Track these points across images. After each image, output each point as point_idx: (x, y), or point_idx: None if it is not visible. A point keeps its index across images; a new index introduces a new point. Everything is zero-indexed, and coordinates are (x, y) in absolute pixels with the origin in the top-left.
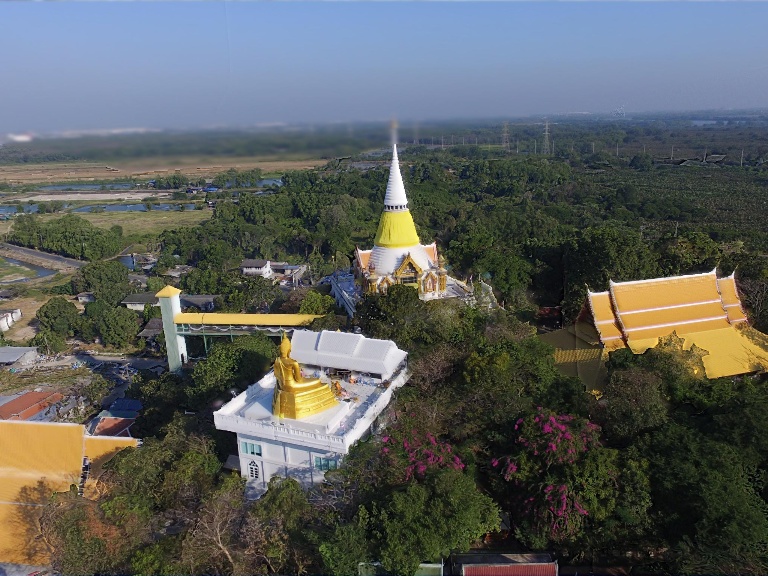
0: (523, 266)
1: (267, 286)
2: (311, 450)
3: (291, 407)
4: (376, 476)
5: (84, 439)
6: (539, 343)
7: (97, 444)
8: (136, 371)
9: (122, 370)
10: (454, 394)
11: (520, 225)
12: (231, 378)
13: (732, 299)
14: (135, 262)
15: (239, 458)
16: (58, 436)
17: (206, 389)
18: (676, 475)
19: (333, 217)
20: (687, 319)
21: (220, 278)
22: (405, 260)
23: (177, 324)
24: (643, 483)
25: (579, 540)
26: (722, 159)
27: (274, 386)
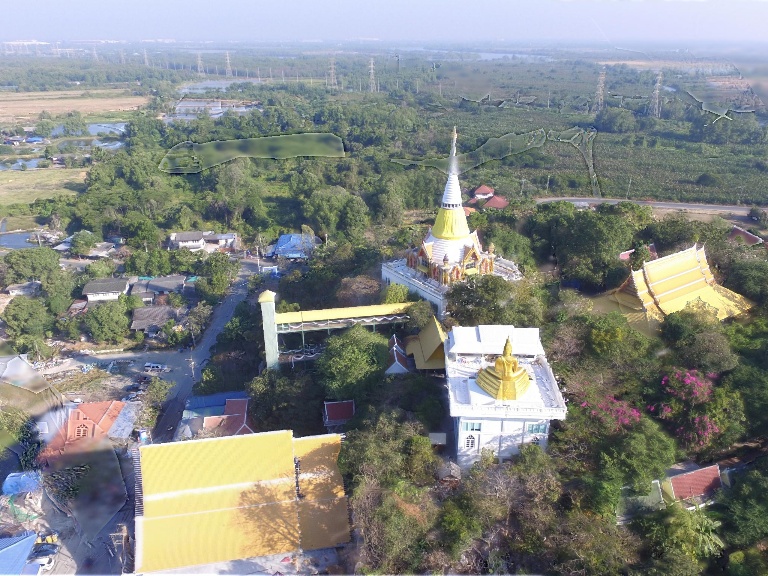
0: (525, 241)
1: (227, 262)
2: (526, 420)
3: (513, 392)
4: (593, 431)
5: (293, 442)
6: (619, 315)
7: (304, 444)
8: (164, 366)
9: (148, 367)
10: (596, 363)
11: (427, 182)
12: (376, 369)
13: (704, 265)
14: (40, 242)
15: (459, 435)
16: (268, 444)
17: (355, 382)
18: (762, 398)
19: (232, 177)
20: (686, 283)
21: (171, 257)
22: (470, 251)
23: (277, 324)
24: (741, 406)
25: (707, 448)
26: (533, 101)
27: (458, 375)
